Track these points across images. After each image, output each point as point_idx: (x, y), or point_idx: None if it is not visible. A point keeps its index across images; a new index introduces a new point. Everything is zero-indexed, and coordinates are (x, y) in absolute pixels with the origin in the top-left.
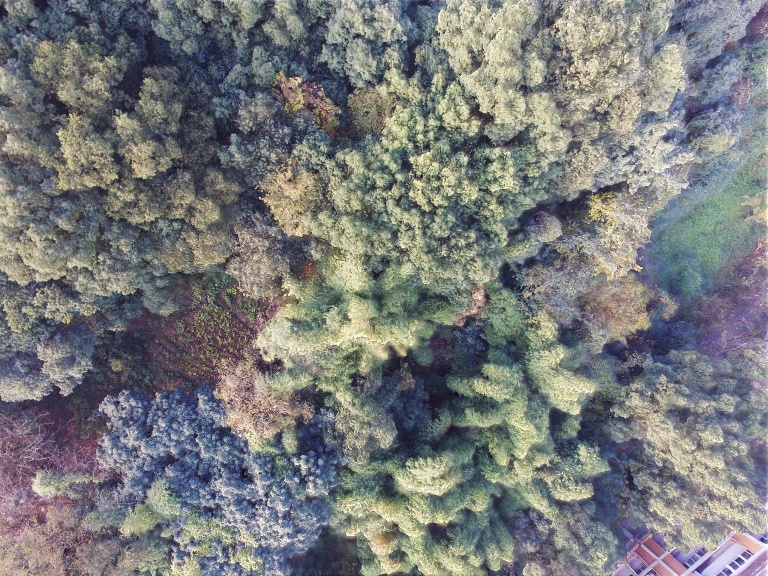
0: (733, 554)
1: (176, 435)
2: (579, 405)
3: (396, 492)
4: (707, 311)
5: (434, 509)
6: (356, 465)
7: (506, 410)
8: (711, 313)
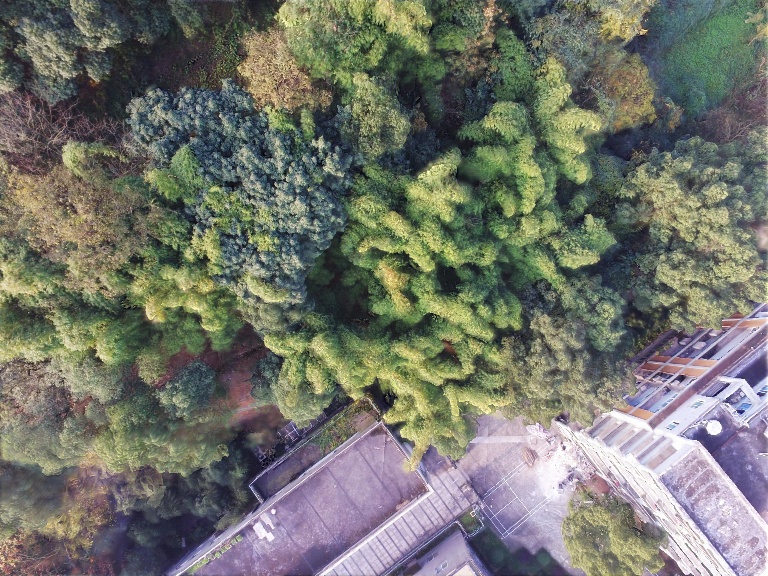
0: (739, 341)
1: (201, 106)
2: (586, 167)
3: (408, 217)
4: (712, 120)
5: (444, 236)
6: (370, 169)
7: (515, 151)
8: (716, 122)
